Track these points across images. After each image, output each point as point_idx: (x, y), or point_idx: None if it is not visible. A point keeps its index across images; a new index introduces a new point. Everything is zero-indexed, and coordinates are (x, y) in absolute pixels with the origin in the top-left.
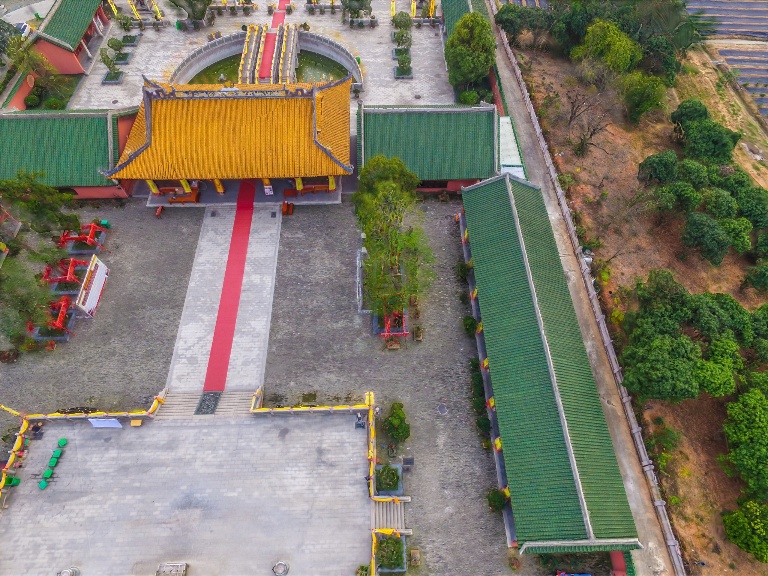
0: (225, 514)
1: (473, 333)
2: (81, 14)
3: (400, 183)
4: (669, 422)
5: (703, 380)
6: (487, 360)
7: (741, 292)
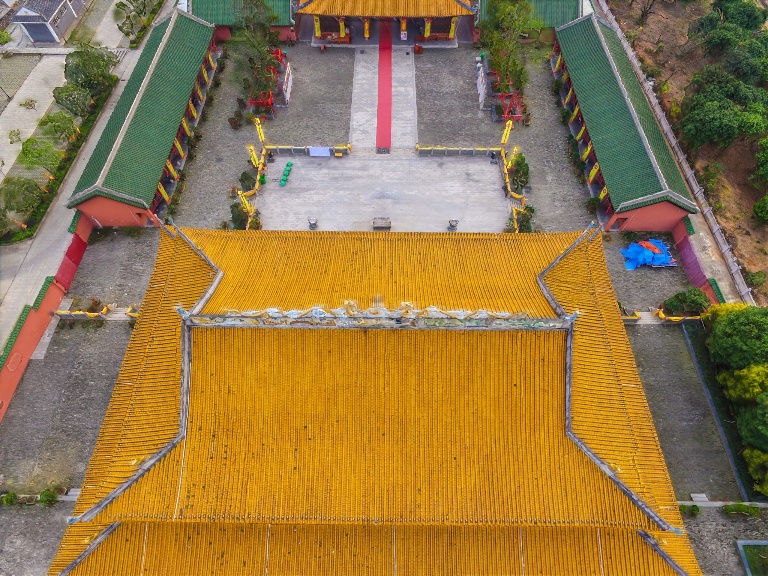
0: (409, 202)
1: (567, 122)
2: None
3: (521, 4)
4: (714, 171)
5: (741, 122)
6: (581, 131)
7: None
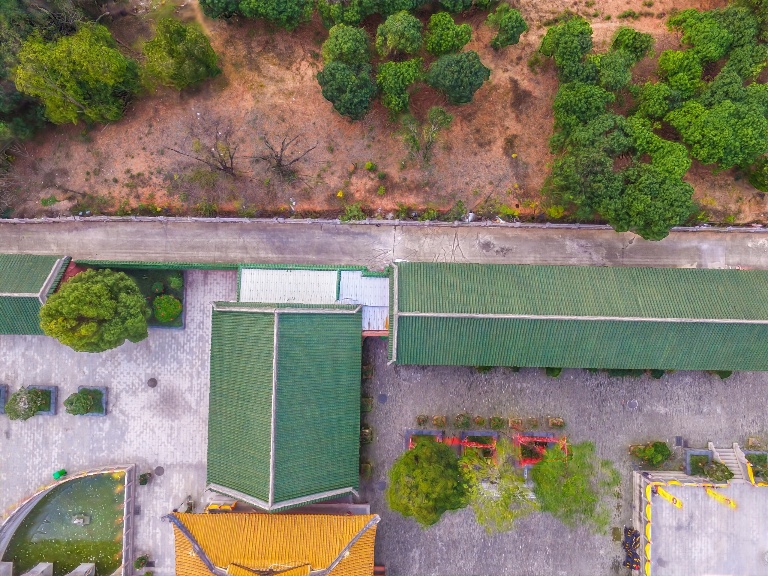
0: None
1: None
2: None
3: (451, 476)
4: None
5: None
6: None
7: (497, 50)
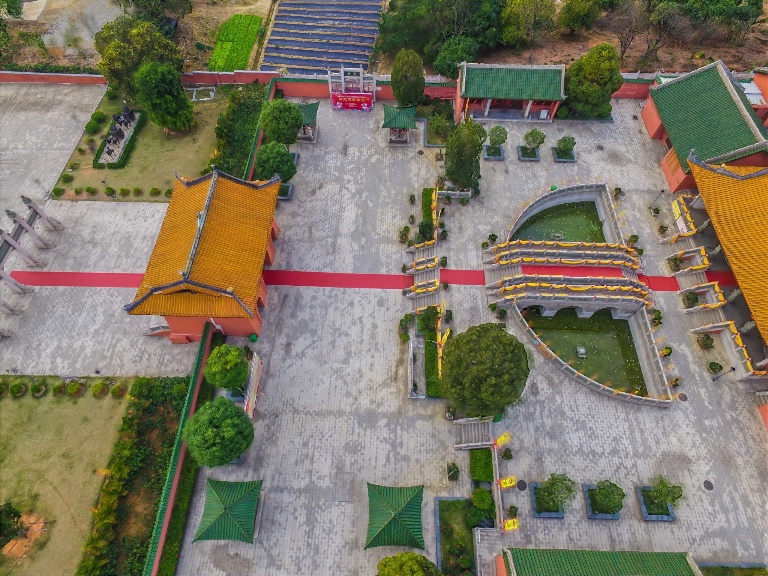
0: None
1: None
2: (585, 568)
3: None
4: None
5: None
6: None
7: None
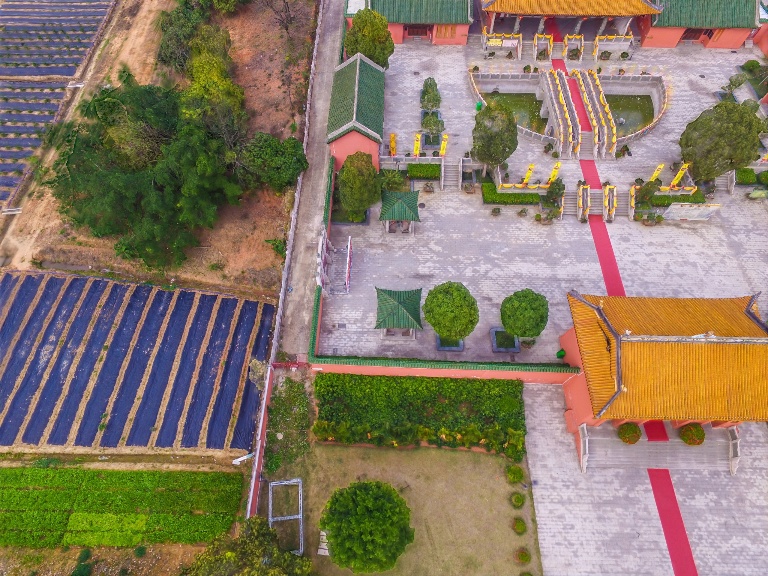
0: None
1: None
2: None
3: None
4: None
5: None
6: None
7: None
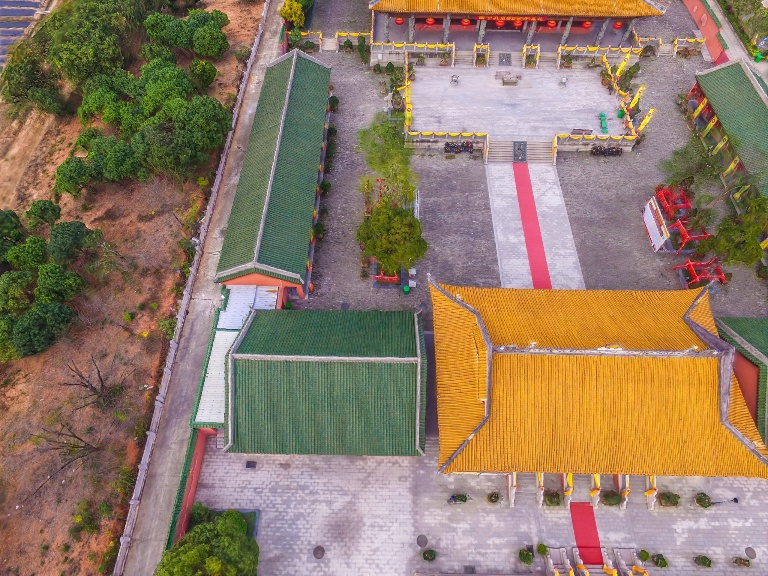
0: (490, 101)
1: None
2: None
3: None
4: None
5: None
6: None
7: None
